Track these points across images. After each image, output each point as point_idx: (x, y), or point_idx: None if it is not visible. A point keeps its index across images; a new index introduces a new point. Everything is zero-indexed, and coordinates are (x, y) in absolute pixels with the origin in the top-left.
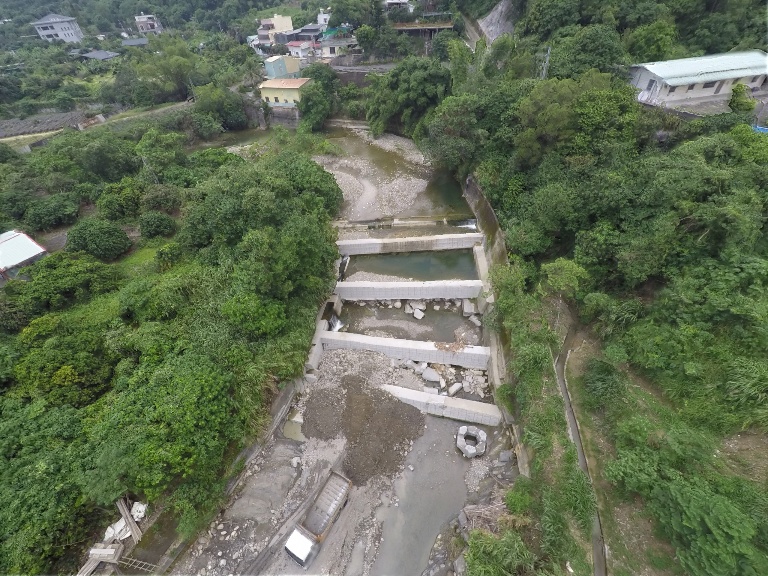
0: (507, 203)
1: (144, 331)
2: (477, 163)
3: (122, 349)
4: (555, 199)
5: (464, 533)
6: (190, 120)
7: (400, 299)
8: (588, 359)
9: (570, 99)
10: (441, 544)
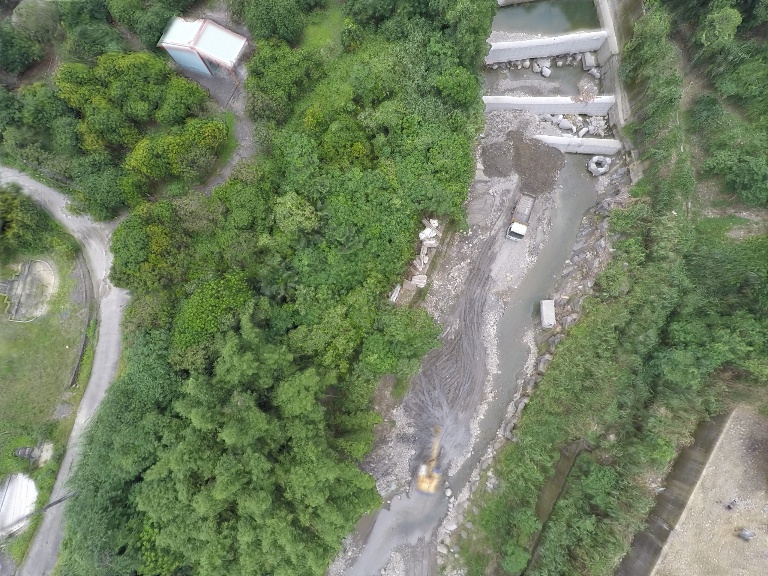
0: None
1: (388, 110)
2: None
3: (376, 126)
4: None
5: (606, 212)
6: None
7: (530, 58)
8: (693, 97)
9: None
10: (587, 221)
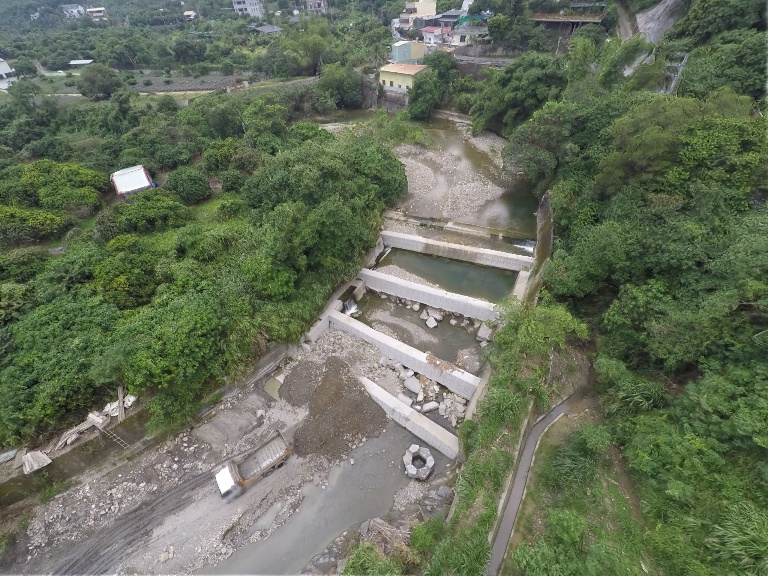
0: (575, 232)
1: (183, 265)
2: (559, 181)
3: (165, 275)
4: (605, 240)
5: (361, 540)
6: (311, 94)
7: (419, 302)
8: None
9: (680, 124)
10: (342, 540)
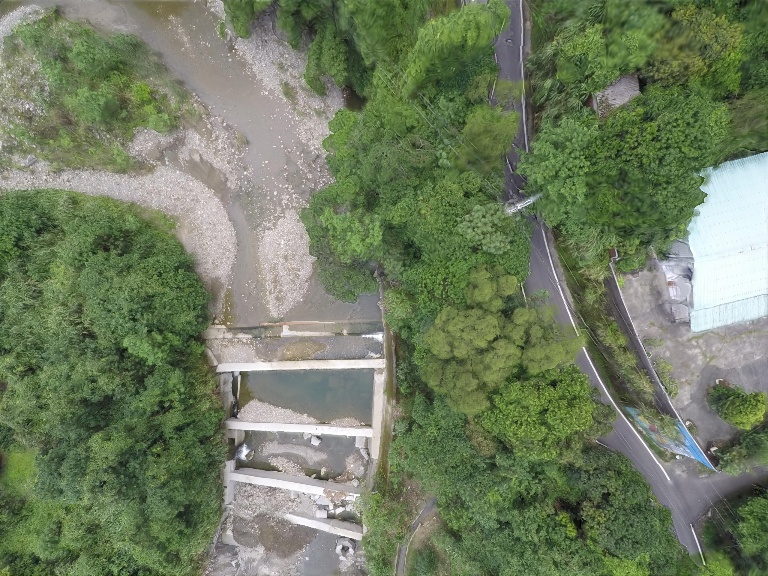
0: (416, 345)
1: None
2: None
3: None
4: None
5: None
6: None
7: None
8: None
9: None
10: None
